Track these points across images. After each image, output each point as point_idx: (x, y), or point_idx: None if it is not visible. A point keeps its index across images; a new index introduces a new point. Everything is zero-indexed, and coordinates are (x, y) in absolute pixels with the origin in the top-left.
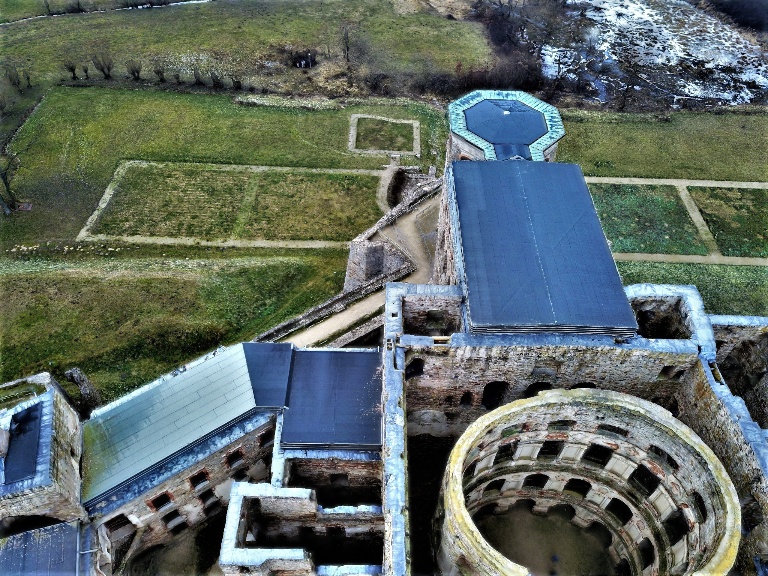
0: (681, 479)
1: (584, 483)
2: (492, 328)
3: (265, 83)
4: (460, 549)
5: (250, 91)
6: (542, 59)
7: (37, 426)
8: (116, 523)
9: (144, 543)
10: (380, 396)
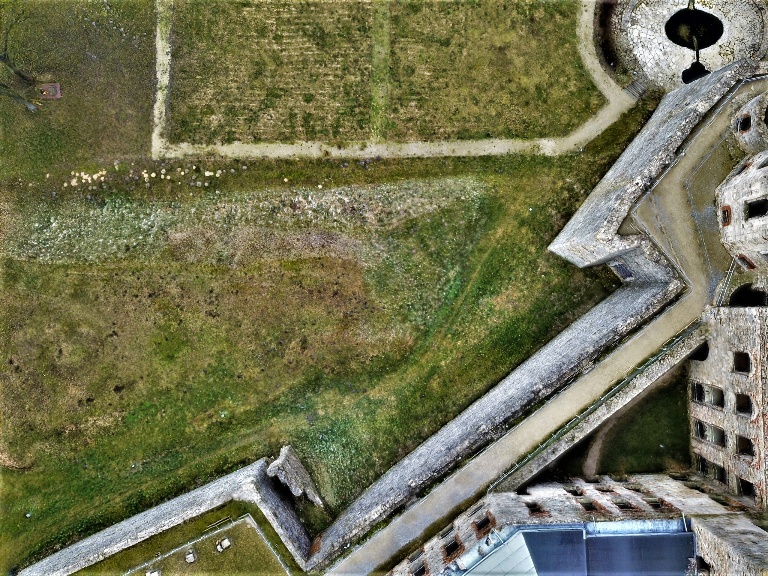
0: None
1: None
2: None
3: None
4: None
5: None
6: None
7: None
8: None
9: None
10: None
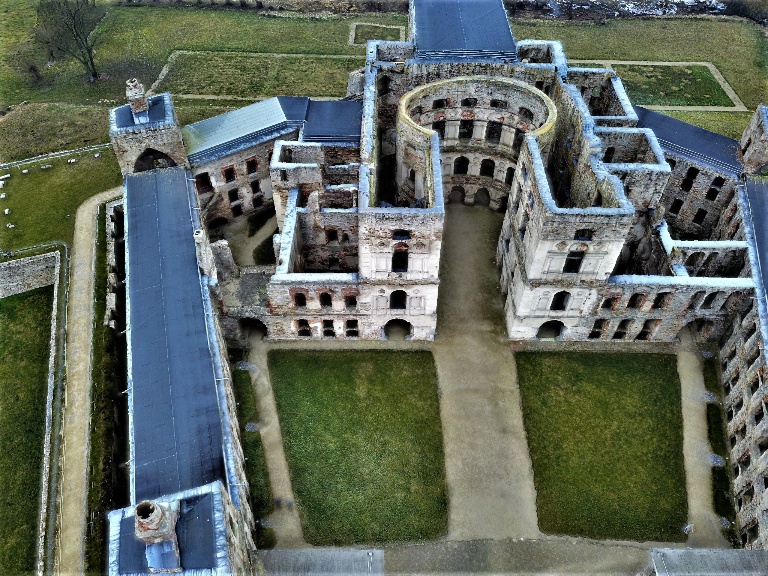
0: (535, 123)
1: (490, 162)
2: (429, 52)
3: (282, 5)
4: (403, 137)
5: (270, 9)
6: None
7: (162, 103)
8: (202, 189)
9: (217, 211)
10: None
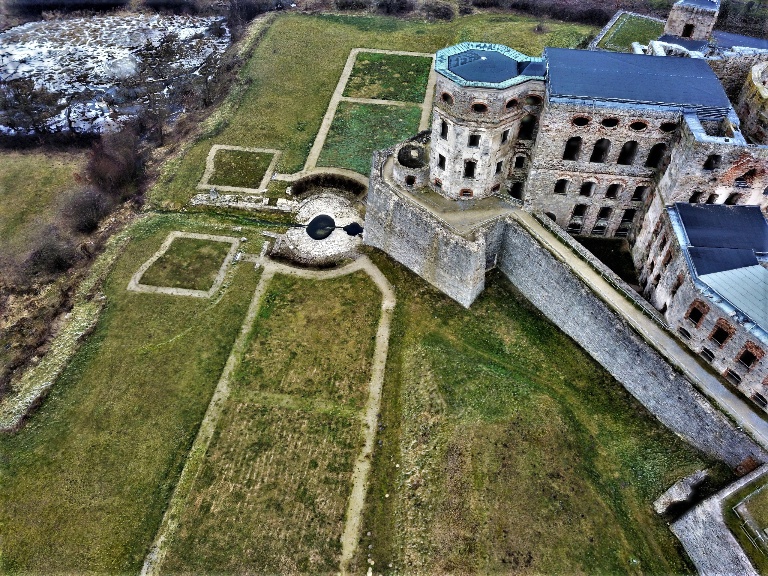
0: (767, 86)
1: None
2: None
3: None
4: None
5: None
6: (77, 128)
7: None
8: None
9: None
10: (718, 206)
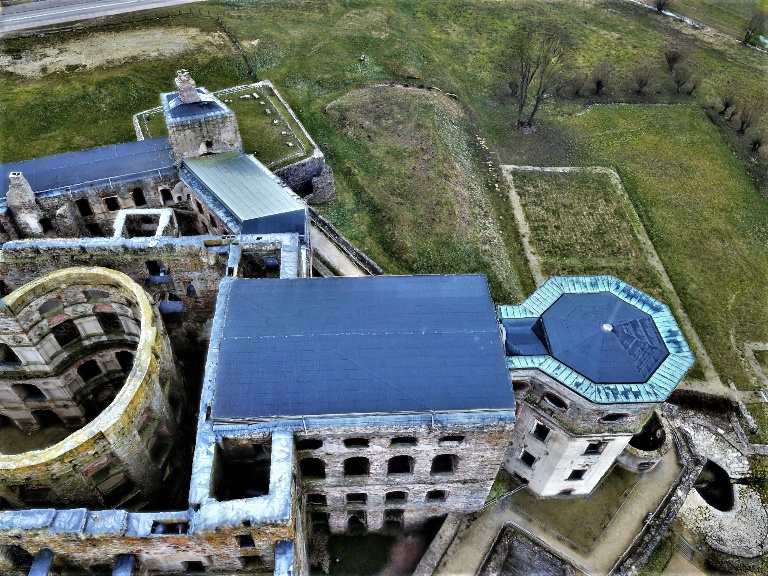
0: None
1: None
2: None
3: None
4: None
5: None
6: None
7: (206, 111)
8: None
9: None
10: None
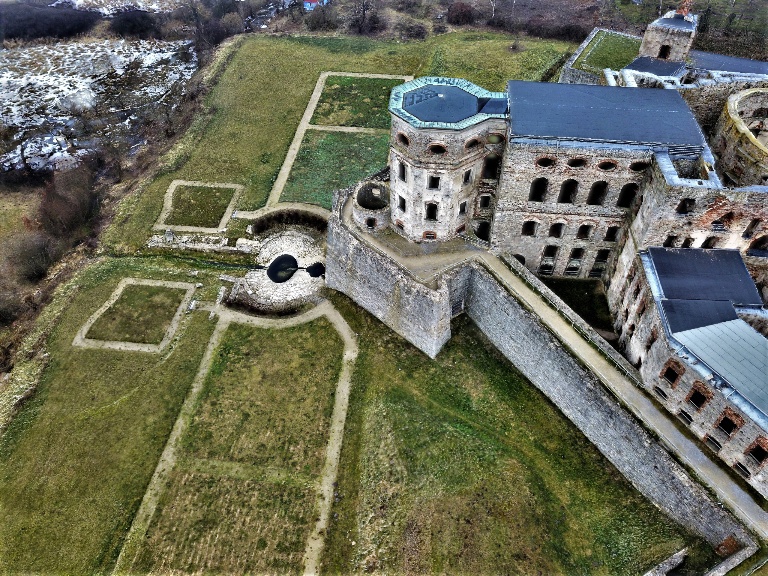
0: None
1: None
2: None
3: None
4: None
5: None
6: (33, 164)
7: None
8: None
9: None
10: (694, 250)
